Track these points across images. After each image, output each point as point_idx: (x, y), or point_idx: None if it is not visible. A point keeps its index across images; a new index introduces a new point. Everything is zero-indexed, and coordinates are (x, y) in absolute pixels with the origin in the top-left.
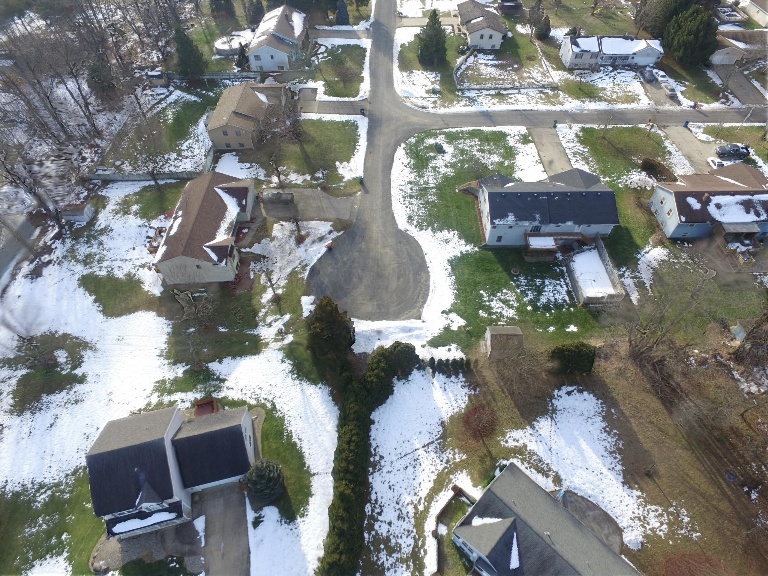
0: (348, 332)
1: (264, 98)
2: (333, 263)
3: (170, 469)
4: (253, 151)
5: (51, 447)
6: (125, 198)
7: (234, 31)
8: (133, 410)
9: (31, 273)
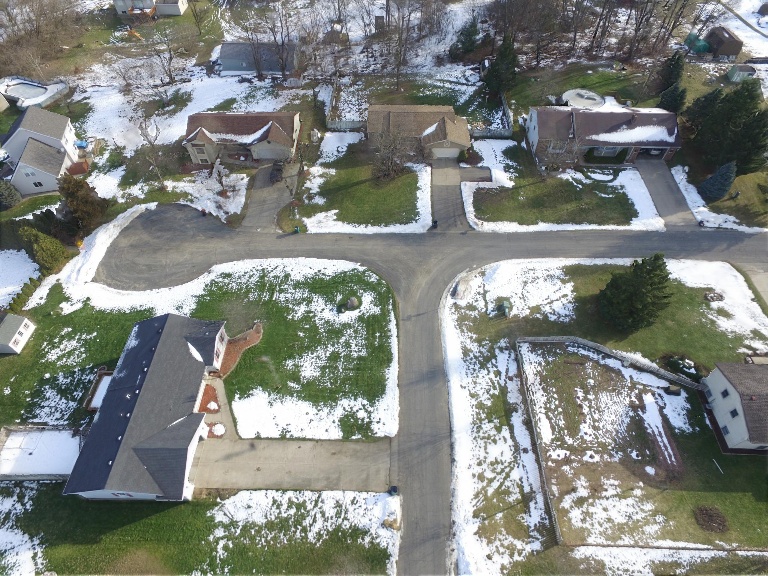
0: (74, 216)
1: (429, 131)
2: (186, 218)
3: (10, 139)
4: (363, 149)
5: (106, 120)
6: (311, 95)
7: (615, 97)
8: (108, 141)
9: (243, 79)
